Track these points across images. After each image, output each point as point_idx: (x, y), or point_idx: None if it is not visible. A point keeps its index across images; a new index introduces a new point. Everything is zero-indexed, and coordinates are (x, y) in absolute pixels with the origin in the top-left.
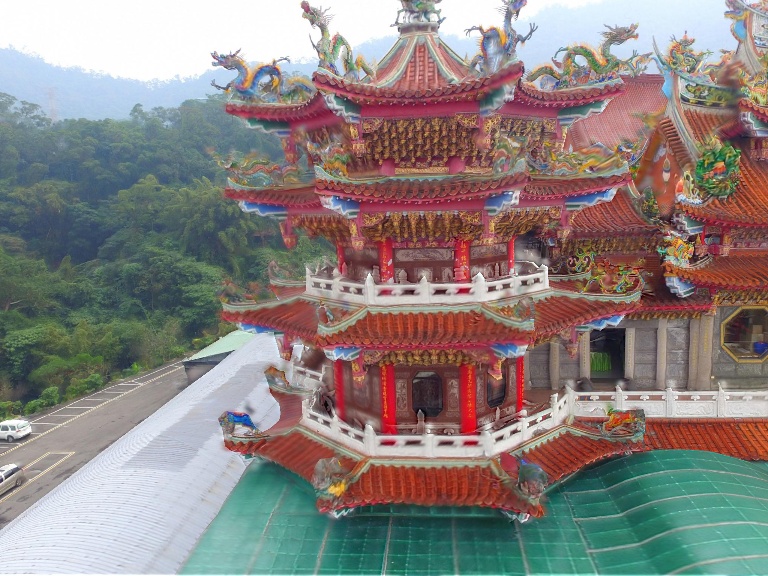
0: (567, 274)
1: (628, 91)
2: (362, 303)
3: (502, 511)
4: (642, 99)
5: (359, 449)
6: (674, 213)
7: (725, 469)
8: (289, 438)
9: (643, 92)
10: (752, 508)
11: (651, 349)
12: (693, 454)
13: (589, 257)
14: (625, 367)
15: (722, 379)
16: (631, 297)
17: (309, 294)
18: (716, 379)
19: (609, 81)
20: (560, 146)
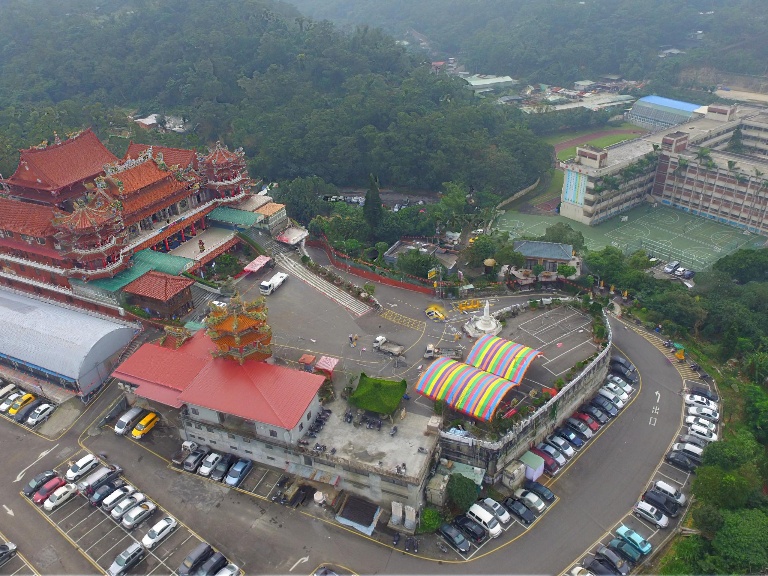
0: None
1: (46, 155)
2: (100, 251)
3: (127, 268)
4: (52, 157)
5: (106, 271)
6: None
7: (145, 251)
8: (91, 276)
9: (50, 154)
10: None
11: None
12: None
13: None
14: None
15: (131, 239)
16: None
17: (85, 253)
18: None
19: None
20: None
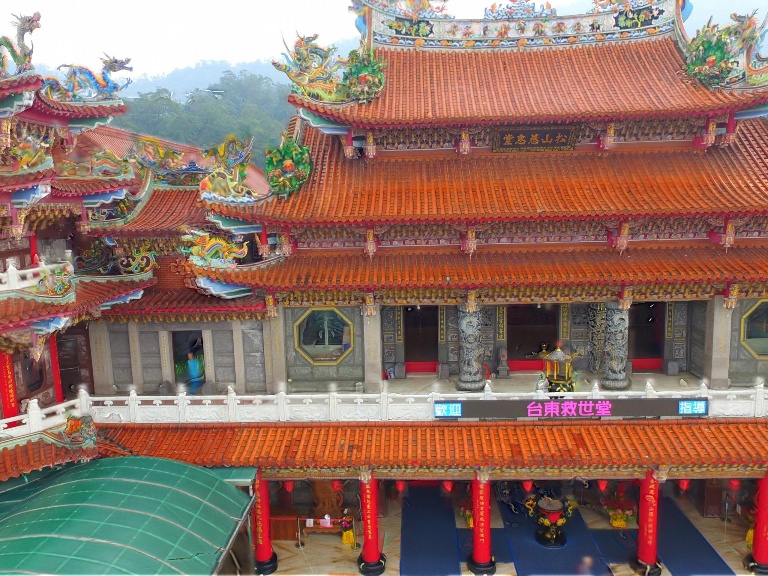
0: (120, 275)
1: None
2: None
3: None
4: None
5: None
6: (206, 212)
7: (141, 477)
8: None
9: None
10: (86, 520)
11: (230, 352)
12: (135, 462)
13: (148, 257)
14: (205, 370)
15: (299, 382)
16: (65, 298)
17: None
18: (293, 382)
19: (23, 73)
20: (2, 141)
